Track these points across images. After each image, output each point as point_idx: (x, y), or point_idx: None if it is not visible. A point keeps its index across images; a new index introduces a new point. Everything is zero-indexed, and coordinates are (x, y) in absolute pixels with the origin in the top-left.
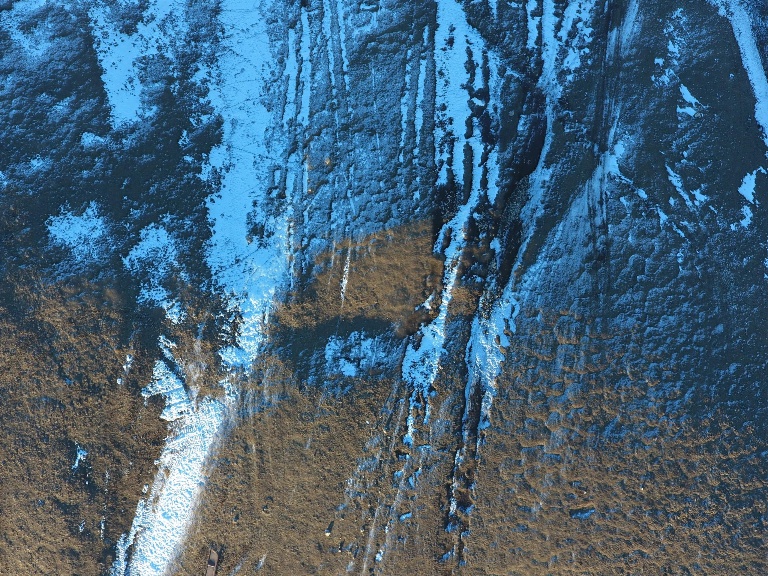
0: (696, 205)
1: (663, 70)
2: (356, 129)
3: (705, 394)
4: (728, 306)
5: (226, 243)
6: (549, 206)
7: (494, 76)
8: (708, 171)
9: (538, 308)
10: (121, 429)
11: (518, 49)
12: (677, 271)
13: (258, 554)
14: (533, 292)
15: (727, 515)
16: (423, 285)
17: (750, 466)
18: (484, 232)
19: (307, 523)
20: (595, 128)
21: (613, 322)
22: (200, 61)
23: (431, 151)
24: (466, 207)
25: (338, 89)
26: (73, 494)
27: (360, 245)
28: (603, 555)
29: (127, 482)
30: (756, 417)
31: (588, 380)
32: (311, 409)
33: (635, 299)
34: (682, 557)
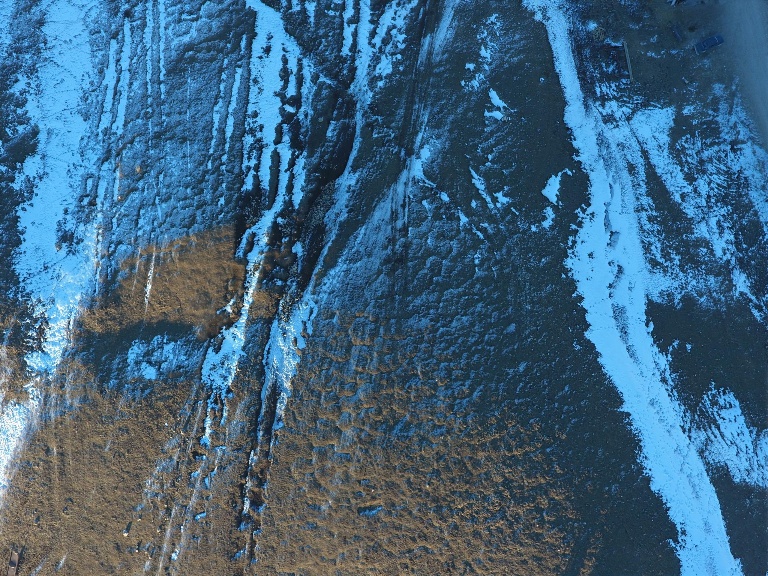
0: (498, 207)
1: (473, 75)
2: (168, 137)
3: (493, 392)
4: (522, 306)
5: (35, 250)
6: (352, 210)
7: (307, 83)
8: (512, 174)
9: (335, 310)
10: None
11: (332, 56)
12: (473, 272)
13: (58, 555)
14: (331, 295)
15: (510, 511)
16: (225, 289)
17: (534, 462)
18: (287, 236)
19: (106, 524)
20: (403, 133)
21: (407, 323)
22: (20, 72)
23: (239, 158)
24: (270, 212)
25: (153, 98)
26: None
27: (164, 251)
28: (389, 551)
29: None
30: (542, 414)
31: (379, 380)
32: (111, 412)
33: (430, 300)
34: (465, 552)
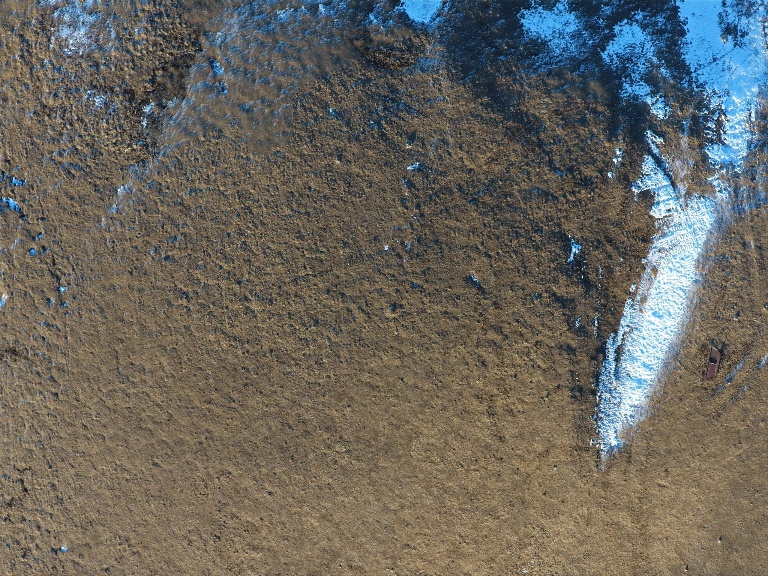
0: None
1: None
2: None
3: None
4: None
5: (701, 41)
6: None
7: None
8: None
9: None
10: (613, 224)
11: None
12: None
13: (760, 352)
14: None
15: None
16: None
17: None
18: None
19: None
20: None
21: None
22: None
23: None
24: None
25: None
26: (570, 287)
27: None
28: None
29: (618, 279)
30: None
31: None
32: None
33: None
34: None
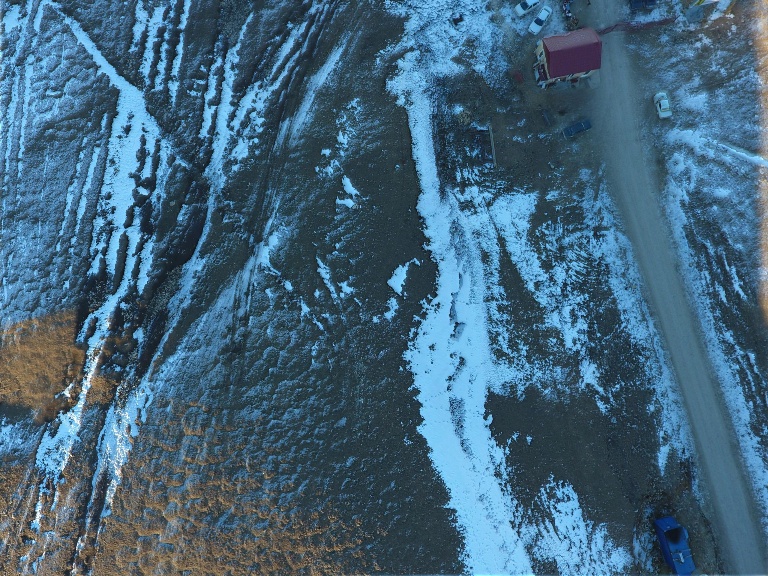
0: (341, 297)
1: (328, 161)
2: (21, 217)
3: (318, 487)
4: (355, 399)
5: None
6: (196, 297)
7: (163, 165)
8: (358, 263)
9: (169, 399)
10: None
11: (189, 138)
12: (309, 364)
13: None
14: (167, 383)
15: None
16: (64, 373)
17: (354, 559)
18: (129, 322)
19: None
20: (253, 219)
21: (239, 414)
22: None
23: (87, 240)
24: (114, 297)
25: (10, 176)
26: None
27: (6, 333)
28: None
29: None
30: (366, 511)
31: (207, 471)
32: None
33: (264, 391)
34: None
